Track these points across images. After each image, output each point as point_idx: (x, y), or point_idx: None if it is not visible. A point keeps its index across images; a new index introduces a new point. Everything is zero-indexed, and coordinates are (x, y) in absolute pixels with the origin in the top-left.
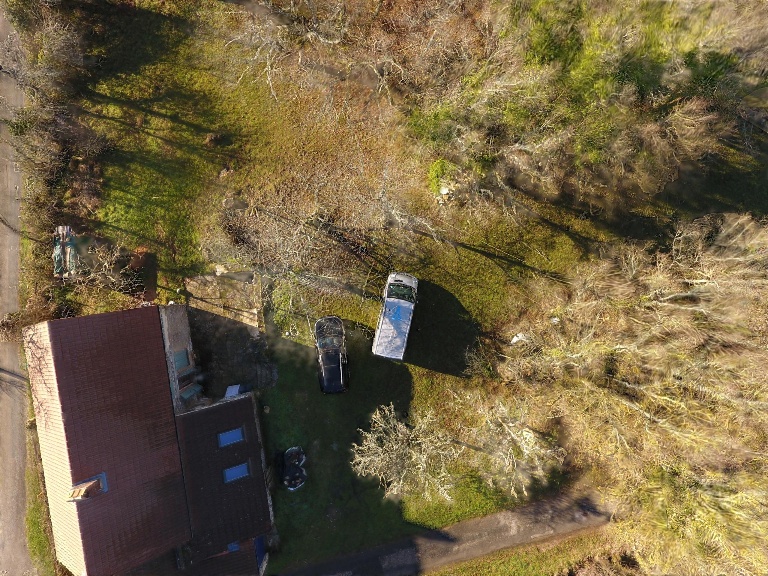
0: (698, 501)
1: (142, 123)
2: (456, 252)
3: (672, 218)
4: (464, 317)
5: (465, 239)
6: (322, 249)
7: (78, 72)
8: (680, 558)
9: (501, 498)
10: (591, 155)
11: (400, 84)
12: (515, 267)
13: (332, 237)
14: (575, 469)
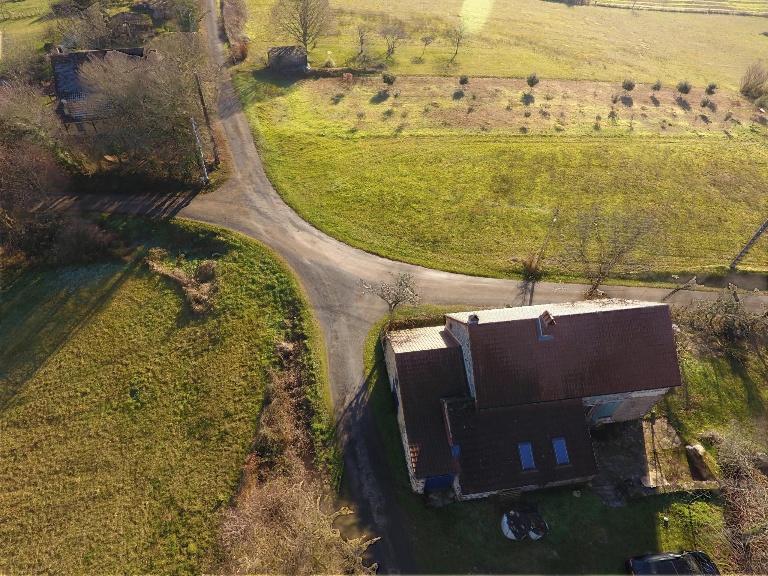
0: None
1: None
2: None
3: None
4: None
5: None
6: None
7: None
8: None
9: None
10: None
11: None
12: None
13: None
14: None
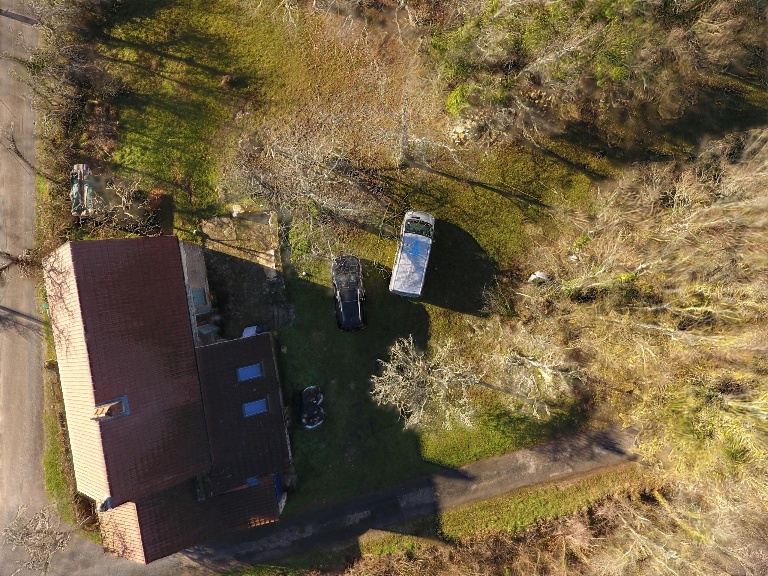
0: (725, 408)
1: (157, 66)
2: (472, 191)
3: (689, 156)
4: (481, 256)
5: (481, 178)
6: (338, 189)
7: (93, 17)
8: (708, 464)
9: (519, 436)
10: (612, 72)
11: (415, 26)
12: (531, 206)
13: (348, 177)
14: (593, 407)
